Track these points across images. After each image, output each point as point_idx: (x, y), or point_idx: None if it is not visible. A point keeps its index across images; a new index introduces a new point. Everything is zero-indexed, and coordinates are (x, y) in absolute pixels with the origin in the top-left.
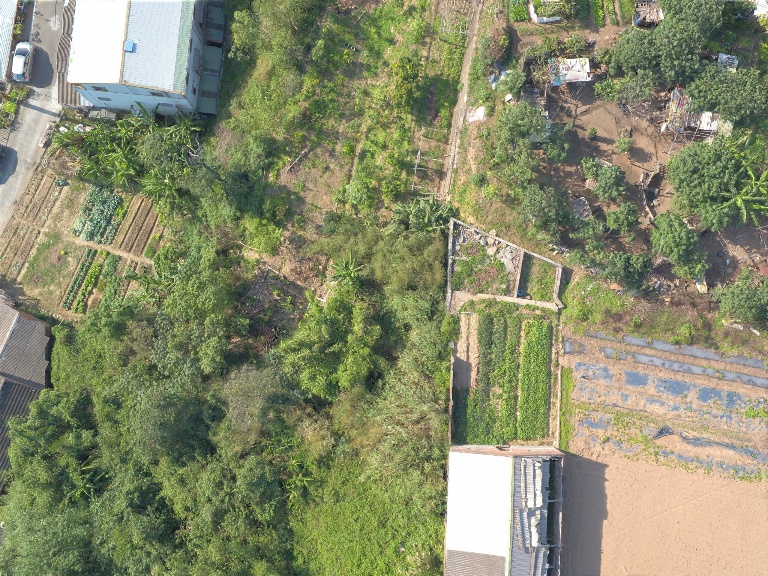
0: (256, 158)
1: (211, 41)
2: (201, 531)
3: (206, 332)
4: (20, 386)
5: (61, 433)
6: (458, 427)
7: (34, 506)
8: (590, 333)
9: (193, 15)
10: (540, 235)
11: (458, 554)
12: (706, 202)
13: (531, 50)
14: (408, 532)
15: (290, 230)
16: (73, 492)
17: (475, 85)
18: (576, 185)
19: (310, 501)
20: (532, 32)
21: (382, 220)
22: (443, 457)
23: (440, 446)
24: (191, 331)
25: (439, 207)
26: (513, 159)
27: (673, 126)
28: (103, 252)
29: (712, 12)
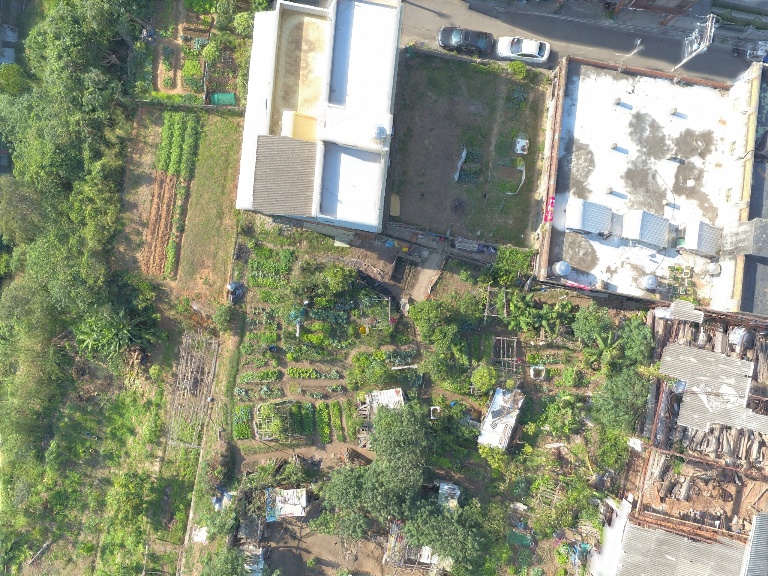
0: None
1: None
2: None
3: None
4: None
5: None
6: None
7: None
8: None
9: None
10: None
11: None
12: None
13: (248, 480)
14: None
15: None
16: None
17: (200, 503)
18: None
19: None
20: (256, 451)
21: None
22: None
23: None
24: None
25: None
26: None
27: (391, 561)
28: None
29: (410, 476)
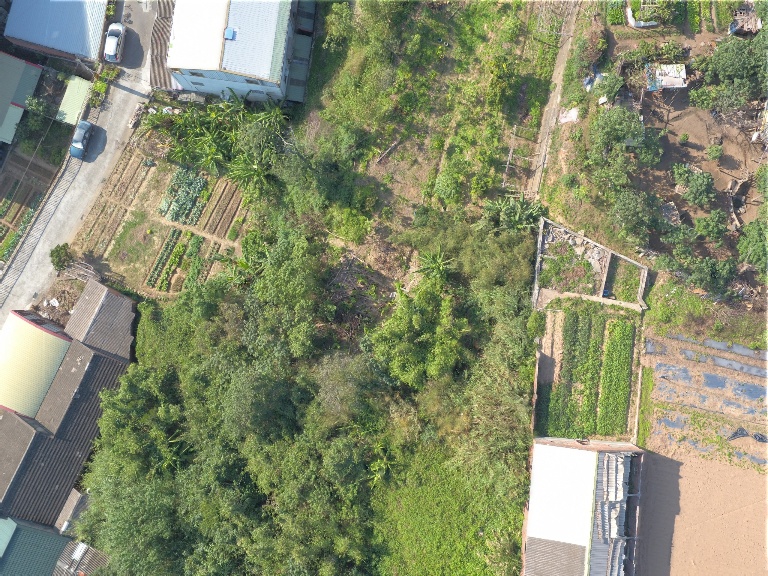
0: (347, 149)
1: (301, 30)
2: (287, 507)
3: (296, 317)
4: (108, 360)
5: (150, 407)
6: (540, 420)
7: (121, 475)
8: (672, 335)
9: (290, 5)
10: (630, 238)
11: (539, 541)
12: None
13: (628, 54)
14: (487, 518)
15: (377, 220)
16: (160, 464)
17: (569, 86)
18: (665, 189)
19: (392, 483)
20: (629, 36)
21: (470, 215)
22: (526, 448)
23: (523, 437)
24: (281, 315)
25: (528, 205)
26: (607, 162)
27: (765, 135)
28: (188, 233)
29: None
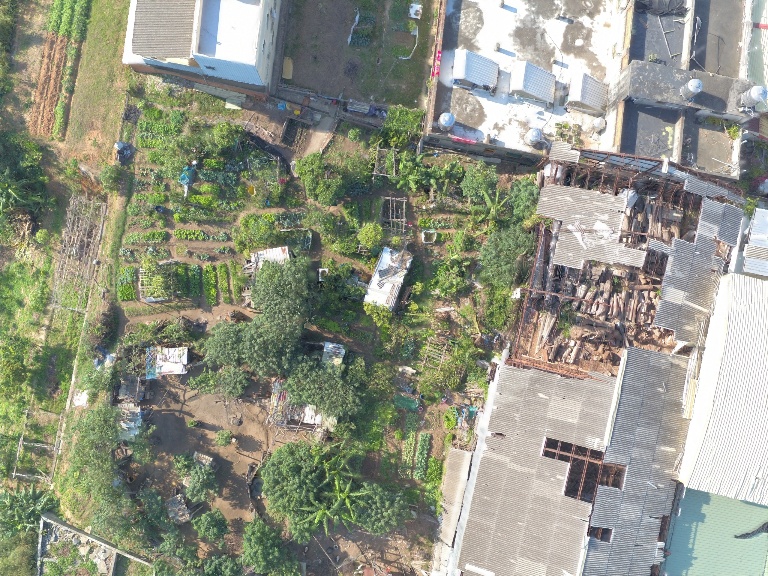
0: None
1: None
2: None
3: None
4: None
5: None
6: None
7: None
8: None
9: None
10: (120, 545)
11: None
12: (289, 514)
13: (129, 338)
14: None
15: None
16: None
17: (82, 366)
18: (180, 476)
19: None
20: (140, 312)
21: None
22: None
23: None
24: None
25: (40, 497)
26: None
27: (274, 421)
28: None
29: (286, 322)
